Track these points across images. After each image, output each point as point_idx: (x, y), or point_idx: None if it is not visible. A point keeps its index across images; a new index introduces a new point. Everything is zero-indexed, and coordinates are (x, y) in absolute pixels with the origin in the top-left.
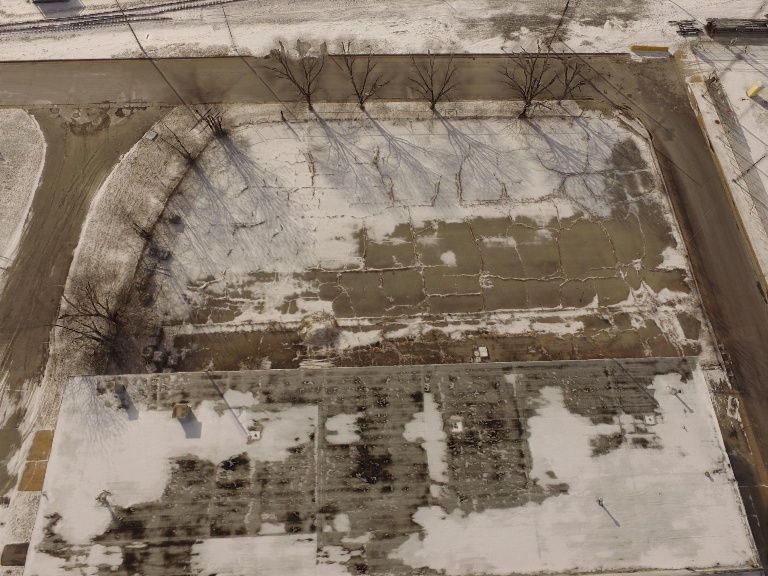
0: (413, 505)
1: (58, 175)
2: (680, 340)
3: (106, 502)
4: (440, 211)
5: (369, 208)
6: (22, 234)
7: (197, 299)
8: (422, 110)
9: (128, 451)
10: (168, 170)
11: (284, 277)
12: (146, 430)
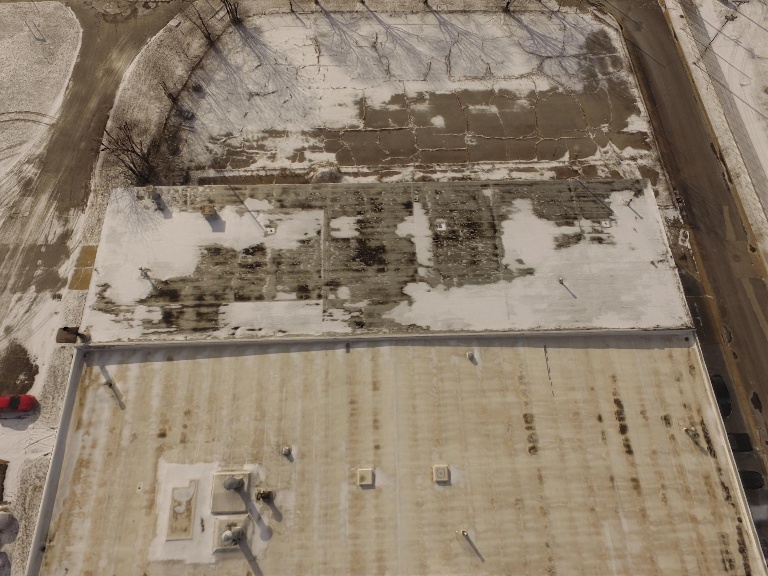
0: (403, 281)
1: (93, 53)
2: None
3: (147, 276)
4: (431, 84)
5: (368, 81)
6: (64, 98)
7: (218, 150)
8: (416, 5)
9: (164, 241)
10: (190, 50)
11: (293, 134)
12: (179, 226)
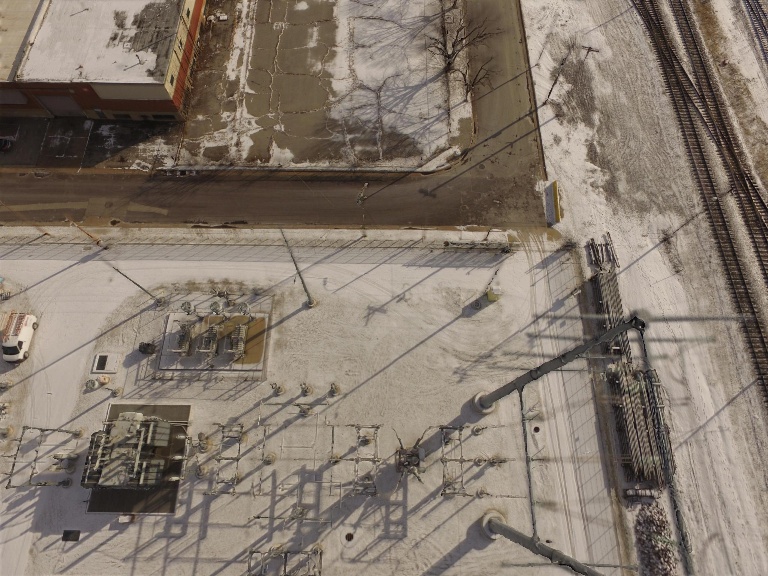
0: None
1: None
2: (205, 142)
3: None
4: (345, 4)
5: None
6: None
7: None
8: (452, 1)
9: None
10: None
11: None
12: None
